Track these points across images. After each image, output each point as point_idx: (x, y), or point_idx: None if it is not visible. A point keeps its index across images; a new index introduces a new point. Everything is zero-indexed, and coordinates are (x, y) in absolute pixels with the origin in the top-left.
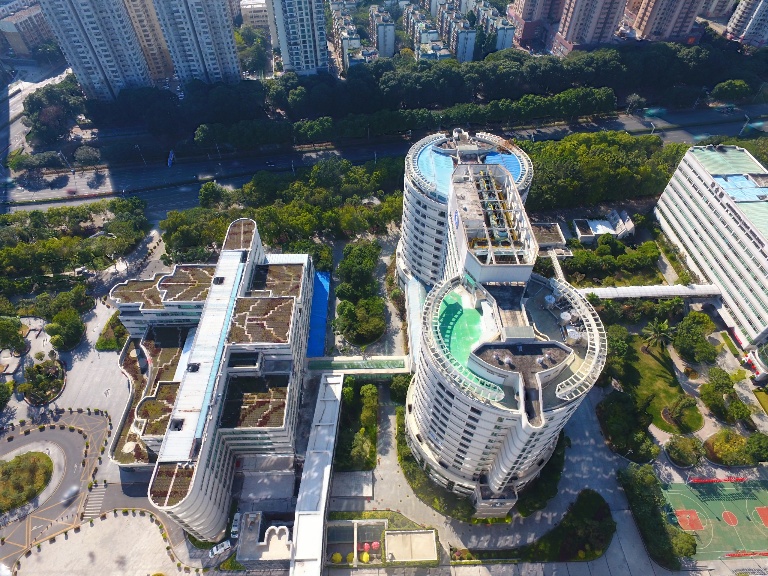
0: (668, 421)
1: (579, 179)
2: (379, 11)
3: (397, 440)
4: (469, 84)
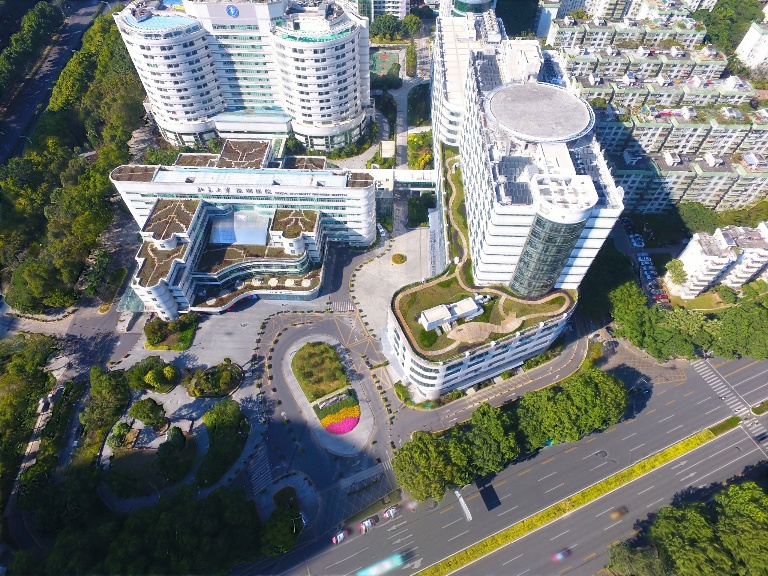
0: None
1: None
2: None
3: (327, 157)
4: None
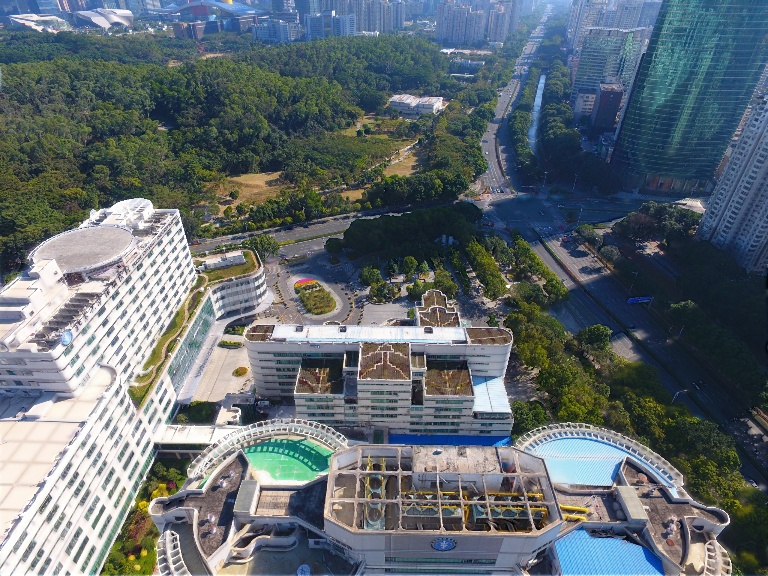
0: None
1: None
2: None
3: None
4: None
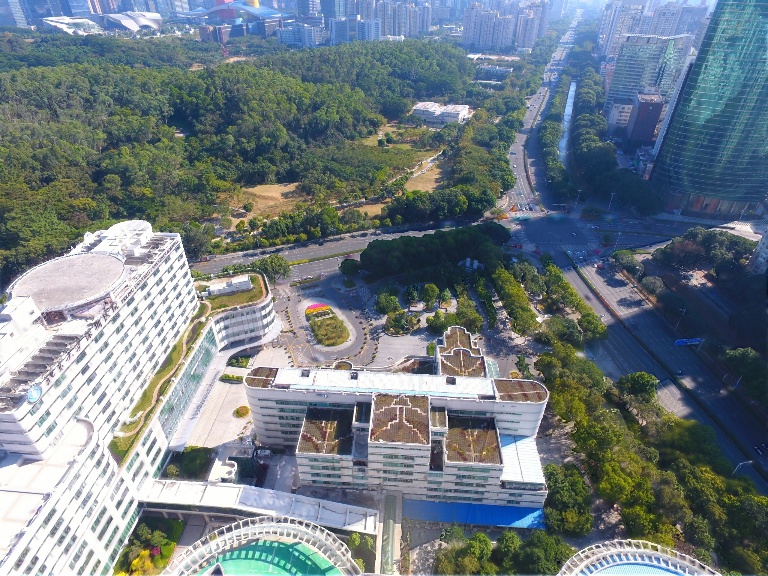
0: None
1: None
2: None
3: None
4: None
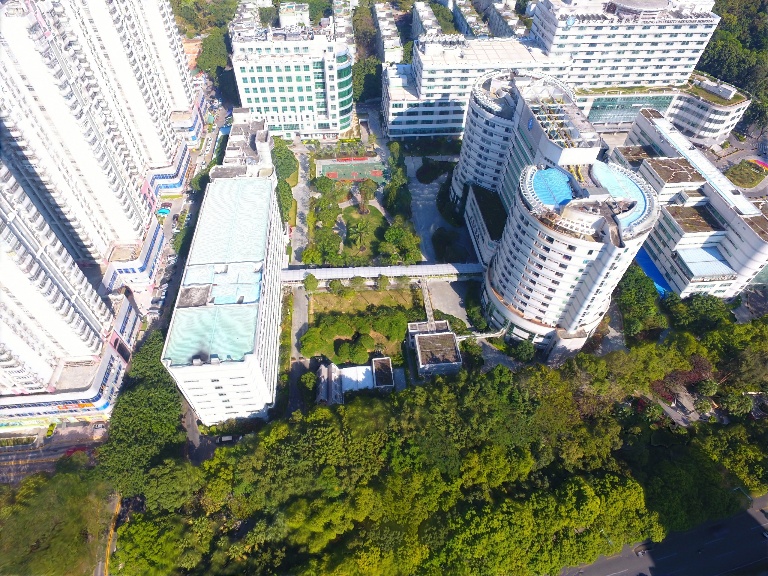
0: None
1: None
2: None
3: None
4: None
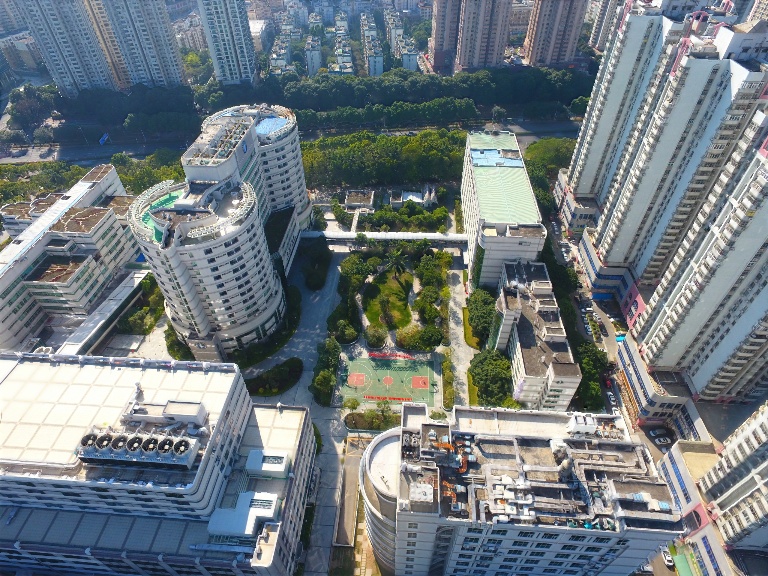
0: (381, 321)
1: (398, 159)
2: (312, 40)
3: None
4: (357, 94)
